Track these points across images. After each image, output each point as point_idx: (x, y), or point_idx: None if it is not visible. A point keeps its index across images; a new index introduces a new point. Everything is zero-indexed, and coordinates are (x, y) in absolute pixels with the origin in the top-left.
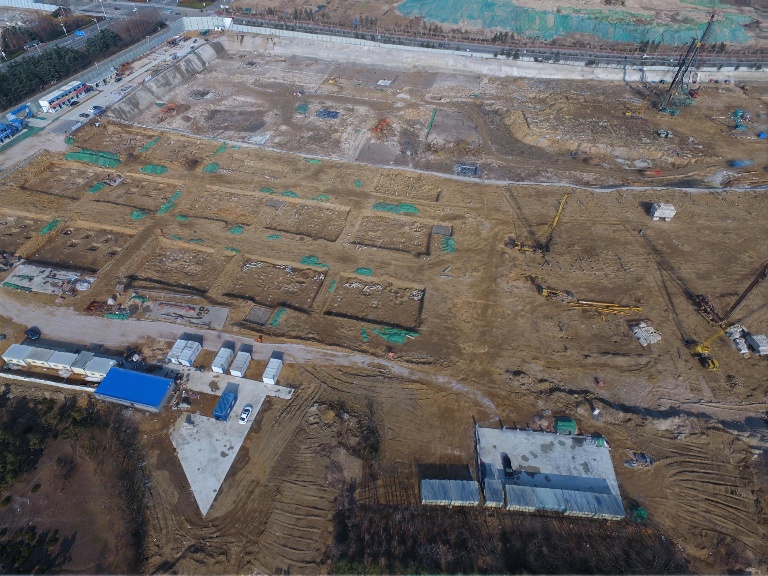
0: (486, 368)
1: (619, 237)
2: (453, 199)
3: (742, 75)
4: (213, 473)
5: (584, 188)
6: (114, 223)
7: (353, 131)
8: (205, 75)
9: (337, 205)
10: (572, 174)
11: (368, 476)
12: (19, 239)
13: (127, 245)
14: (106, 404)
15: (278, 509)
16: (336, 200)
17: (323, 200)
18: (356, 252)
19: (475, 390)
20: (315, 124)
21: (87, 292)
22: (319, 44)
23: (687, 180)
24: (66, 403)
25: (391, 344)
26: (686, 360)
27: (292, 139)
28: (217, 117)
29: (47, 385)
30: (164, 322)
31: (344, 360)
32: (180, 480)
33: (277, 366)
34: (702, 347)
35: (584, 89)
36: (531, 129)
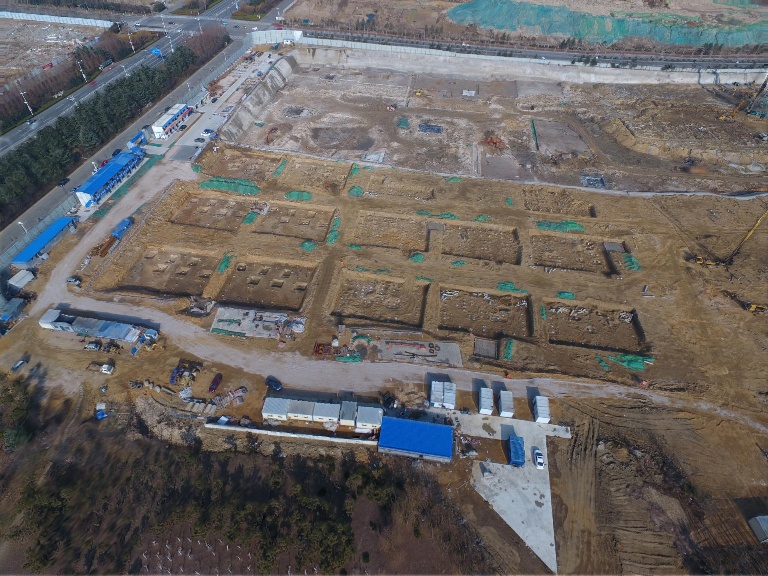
0: (738, 391)
1: None
2: (610, 214)
3: None
4: (539, 525)
5: (726, 196)
6: (289, 256)
7: (465, 145)
8: (290, 91)
9: (500, 225)
10: (696, 181)
11: (692, 516)
12: (195, 278)
13: (315, 280)
14: (391, 457)
15: (626, 560)
16: (498, 220)
17: (485, 221)
18: (547, 275)
19: (742, 415)
20: (424, 139)
21: (304, 334)
22: (393, 55)
23: None
24: (345, 459)
25: (634, 371)
26: None
27: (409, 156)
28: (321, 135)
29: (318, 440)
30: (401, 362)
31: (601, 392)
32: (510, 536)
33: (547, 404)
34: None
35: (666, 94)
36: (637, 137)
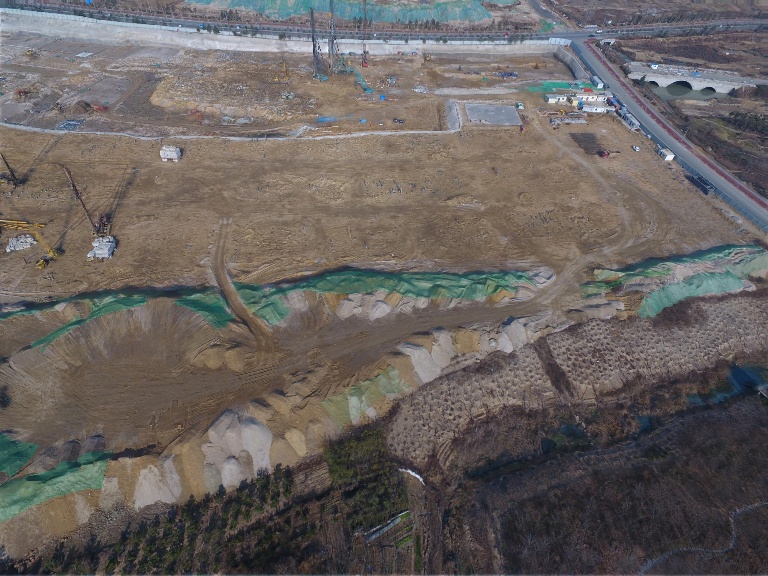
0: None
1: (109, 174)
2: None
3: (431, 48)
4: None
5: (133, 136)
6: None
7: None
8: None
9: None
10: (163, 128)
11: None
12: None
13: None
14: None
15: None
16: None
17: None
18: None
19: None
20: None
21: None
22: (43, 21)
23: (270, 134)
24: None
25: None
26: (30, 262)
27: None
28: None
29: None
30: None
31: None
32: None
33: None
34: (48, 251)
35: (266, 60)
36: (169, 92)
